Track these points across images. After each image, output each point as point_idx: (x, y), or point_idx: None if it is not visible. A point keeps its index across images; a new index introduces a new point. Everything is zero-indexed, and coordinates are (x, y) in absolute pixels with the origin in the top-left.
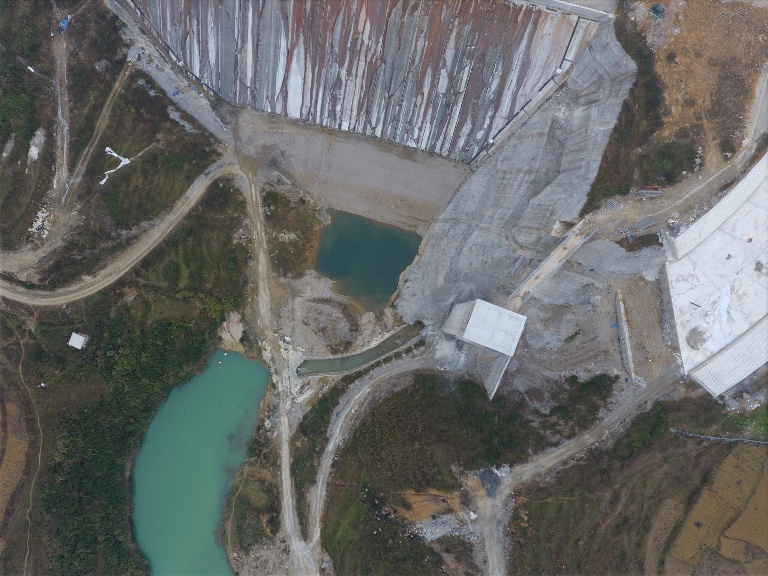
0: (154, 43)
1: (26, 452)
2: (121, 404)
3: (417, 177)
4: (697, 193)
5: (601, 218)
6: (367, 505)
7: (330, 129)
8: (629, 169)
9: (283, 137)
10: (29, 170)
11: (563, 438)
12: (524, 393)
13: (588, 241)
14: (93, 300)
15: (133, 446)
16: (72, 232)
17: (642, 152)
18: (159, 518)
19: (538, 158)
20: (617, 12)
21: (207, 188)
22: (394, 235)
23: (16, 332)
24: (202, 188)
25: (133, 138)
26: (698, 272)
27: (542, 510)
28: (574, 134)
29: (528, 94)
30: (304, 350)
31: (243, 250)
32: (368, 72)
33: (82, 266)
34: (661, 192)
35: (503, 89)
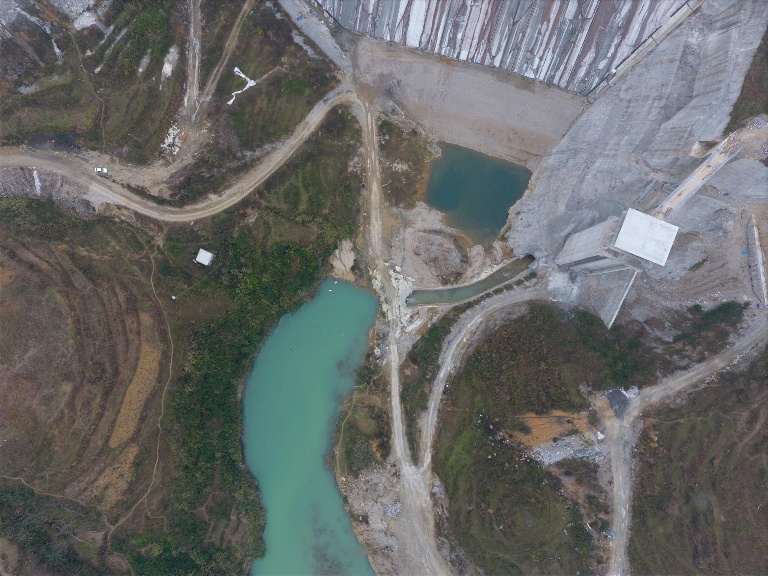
0: None
1: (159, 361)
2: (242, 323)
3: (533, 109)
4: None
5: (746, 136)
6: (481, 430)
7: (448, 58)
8: None
9: (400, 66)
10: (163, 86)
11: (693, 362)
12: (643, 322)
13: (729, 161)
14: (220, 218)
15: (247, 368)
16: (202, 149)
17: None
18: (267, 442)
19: (669, 83)
20: None
21: (326, 114)
22: (503, 170)
23: (146, 247)
24: (321, 114)
25: (259, 60)
26: None
27: (674, 430)
28: (709, 58)
29: (659, 20)
30: (414, 280)
31: (357, 179)
32: None
33: (210, 184)
34: None
35: (633, 15)
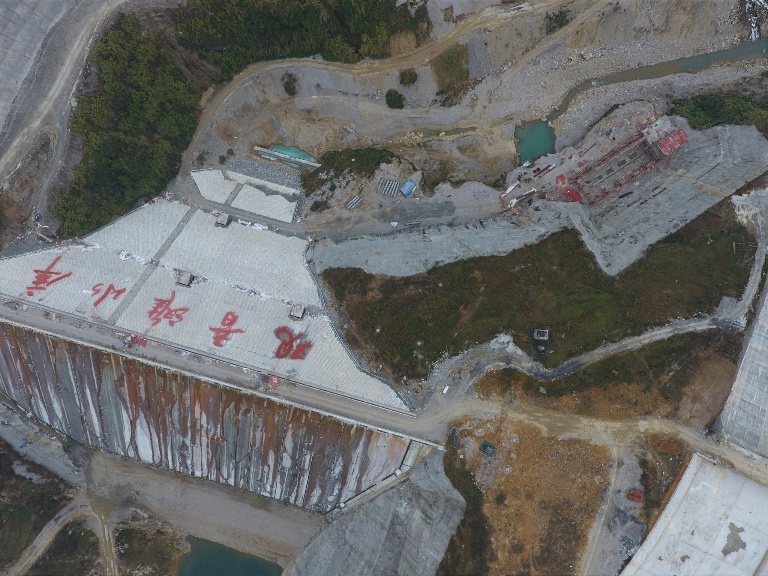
0: (0, 399)
1: None
2: None
3: (272, 524)
4: None
5: None
6: None
7: (184, 475)
8: None
9: (137, 479)
10: None
11: None
12: None
13: None
14: None
15: None
16: None
17: None
18: None
19: (377, 554)
20: (447, 446)
21: (56, 536)
22: (255, 563)
23: None
24: (51, 536)
25: None
26: None
27: None
28: (411, 540)
29: (372, 480)
30: None
31: None
32: (212, 444)
33: None
34: None
35: (347, 474)
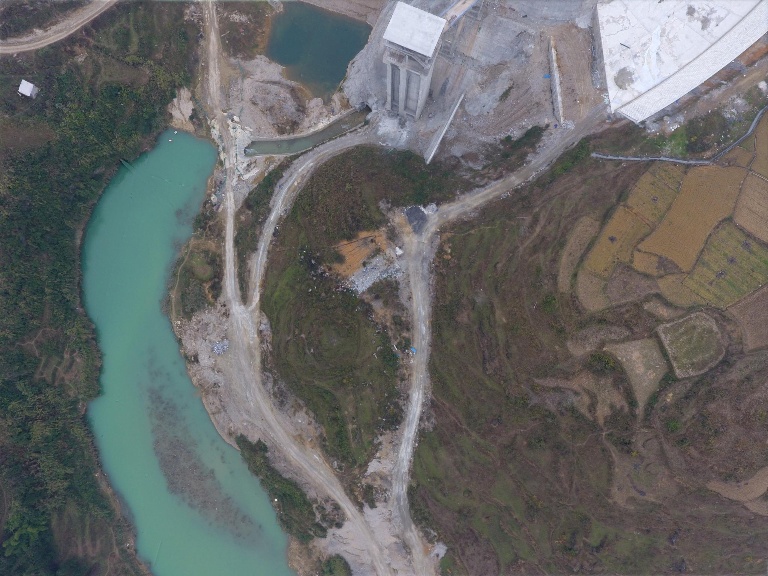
0: None
1: None
2: (69, 159)
3: None
4: None
5: None
6: (304, 266)
7: None
8: None
9: None
10: None
11: (490, 180)
12: (460, 157)
13: None
14: (43, 51)
15: (83, 212)
16: None
17: None
18: (108, 290)
19: None
20: None
21: None
22: (345, 26)
23: None
24: None
25: None
26: (629, 14)
27: (464, 240)
28: None
29: None
30: (252, 130)
31: (194, 28)
32: None
33: (33, 17)
34: None
35: None
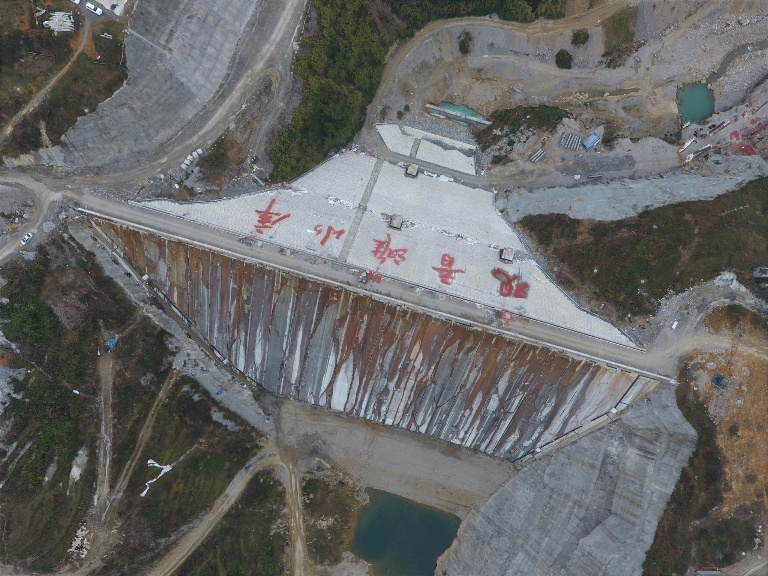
0: (200, 344)
1: None
2: None
3: (460, 472)
4: (755, 573)
5: None
6: None
7: (374, 423)
8: (687, 545)
9: (325, 428)
10: (70, 491)
11: None
12: None
13: None
14: None
15: None
16: (111, 551)
17: (700, 525)
18: None
19: (589, 493)
20: (679, 379)
21: (247, 484)
22: (433, 514)
23: None
24: (242, 484)
25: (175, 445)
26: None
27: None
28: (627, 477)
29: (580, 421)
30: None
31: (280, 539)
32: (417, 388)
33: None
34: (719, 573)
35: (555, 415)
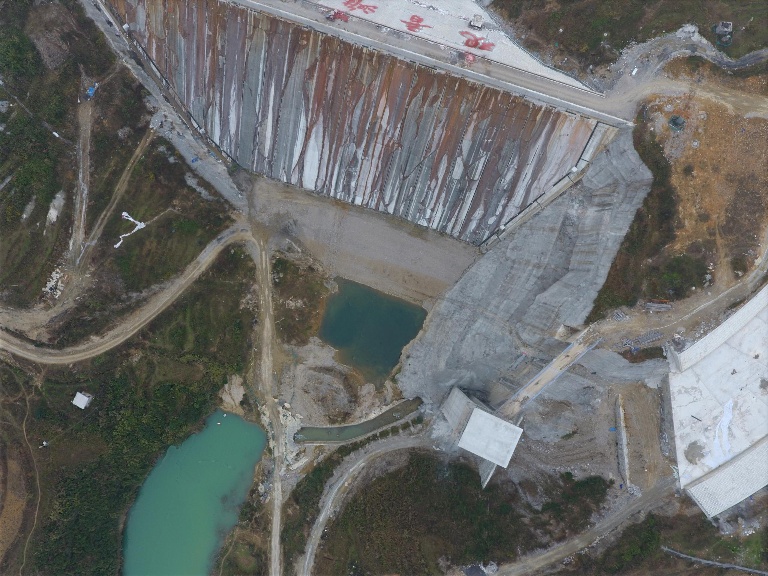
0: (177, 110)
1: (23, 510)
2: (119, 463)
3: (426, 255)
4: (705, 309)
5: (606, 328)
6: None
7: (343, 202)
8: (638, 280)
9: (297, 207)
10: (47, 232)
11: (553, 540)
12: (518, 484)
13: None
14: (99, 361)
15: (128, 501)
16: (84, 294)
17: (652, 263)
18: (148, 572)
19: (548, 254)
20: (636, 121)
21: (218, 254)
22: (400, 307)
23: (23, 388)
24: (214, 253)
25: (150, 203)
26: (701, 385)
27: None
28: (585, 234)
29: (542, 187)
30: (302, 417)
31: (249, 315)
32: (384, 154)
33: (91, 327)
34: (668, 306)
35: (517, 181)
